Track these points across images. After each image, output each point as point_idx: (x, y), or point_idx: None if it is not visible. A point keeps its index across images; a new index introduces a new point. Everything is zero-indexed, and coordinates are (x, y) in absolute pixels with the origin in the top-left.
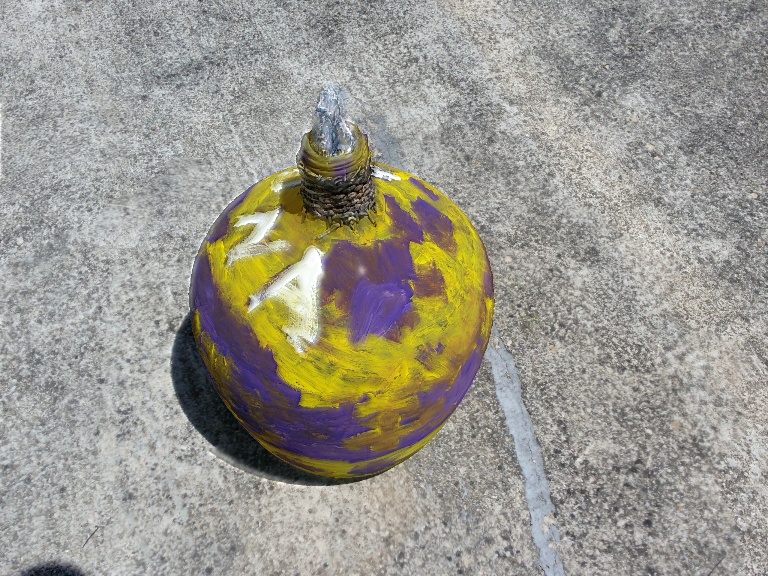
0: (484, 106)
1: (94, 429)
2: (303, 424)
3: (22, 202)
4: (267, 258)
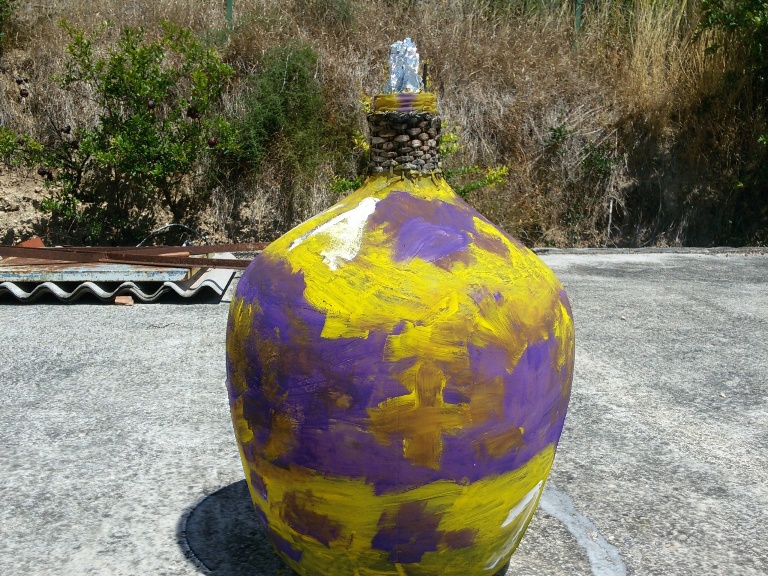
0: (589, 405)
1: (76, 544)
2: (322, 373)
3: (100, 417)
4: None
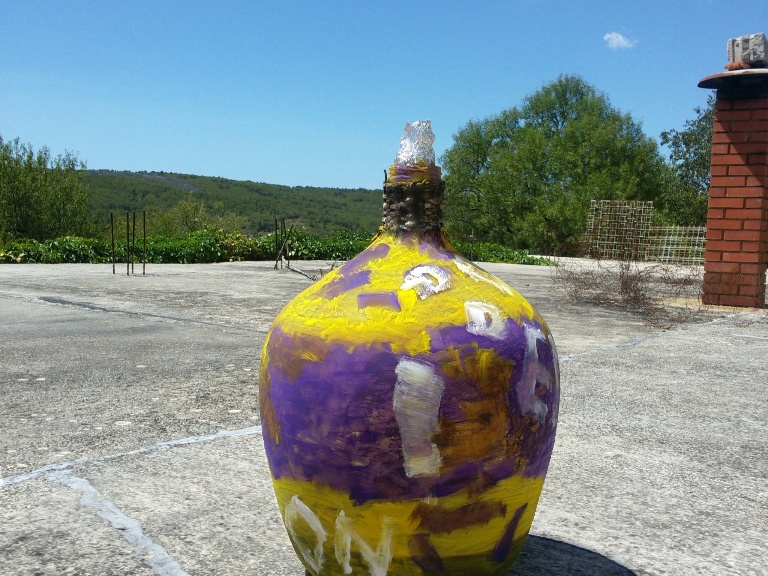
0: None
1: None
2: None
3: None
4: None
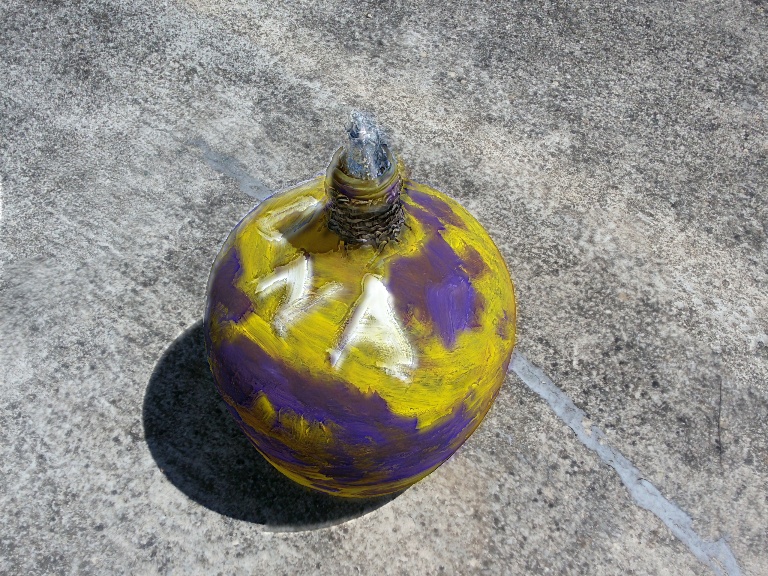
0: (287, 91)
1: None
2: (418, 446)
3: None
4: (324, 306)
